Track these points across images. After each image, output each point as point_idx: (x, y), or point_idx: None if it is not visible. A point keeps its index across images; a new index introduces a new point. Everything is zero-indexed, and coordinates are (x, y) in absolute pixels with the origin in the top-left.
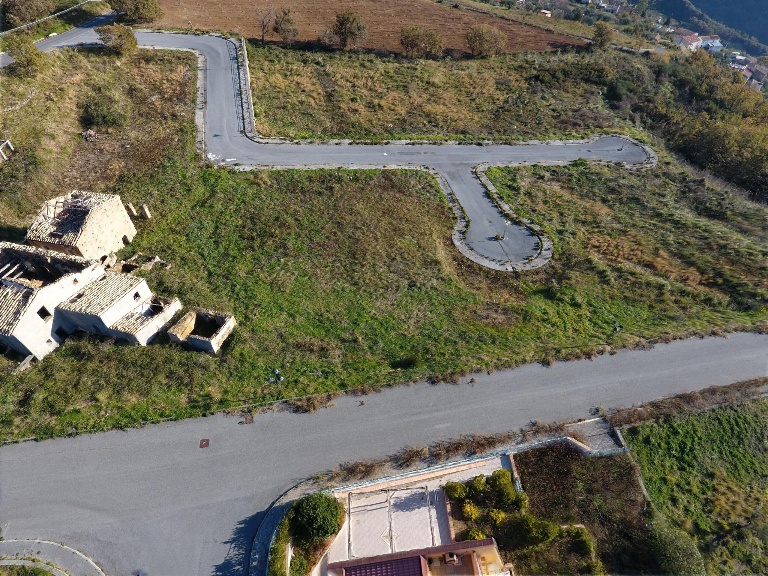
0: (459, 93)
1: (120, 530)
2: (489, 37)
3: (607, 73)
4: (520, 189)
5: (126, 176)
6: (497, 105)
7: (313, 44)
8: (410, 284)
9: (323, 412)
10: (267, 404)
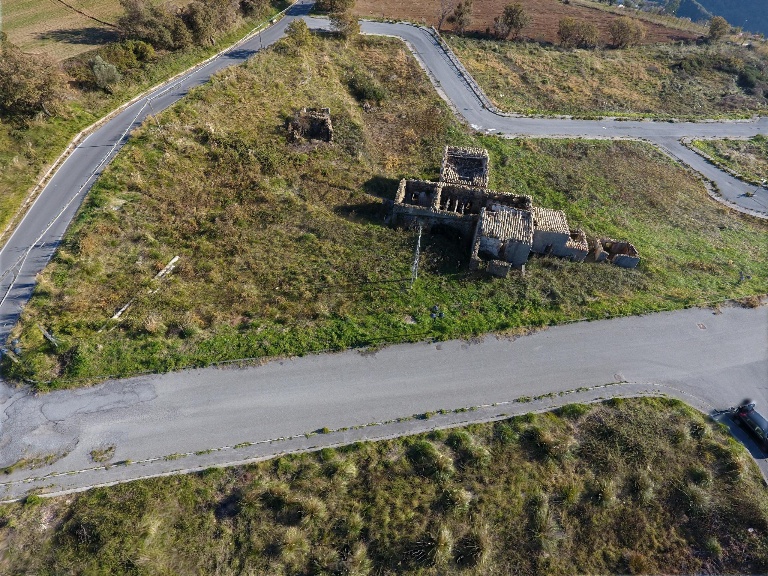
0: (621, 78)
1: (696, 379)
2: (633, 29)
3: (736, 63)
4: (730, 158)
5: (428, 140)
6: (657, 89)
7: (479, 33)
8: (720, 226)
9: (763, 308)
10: (722, 301)
